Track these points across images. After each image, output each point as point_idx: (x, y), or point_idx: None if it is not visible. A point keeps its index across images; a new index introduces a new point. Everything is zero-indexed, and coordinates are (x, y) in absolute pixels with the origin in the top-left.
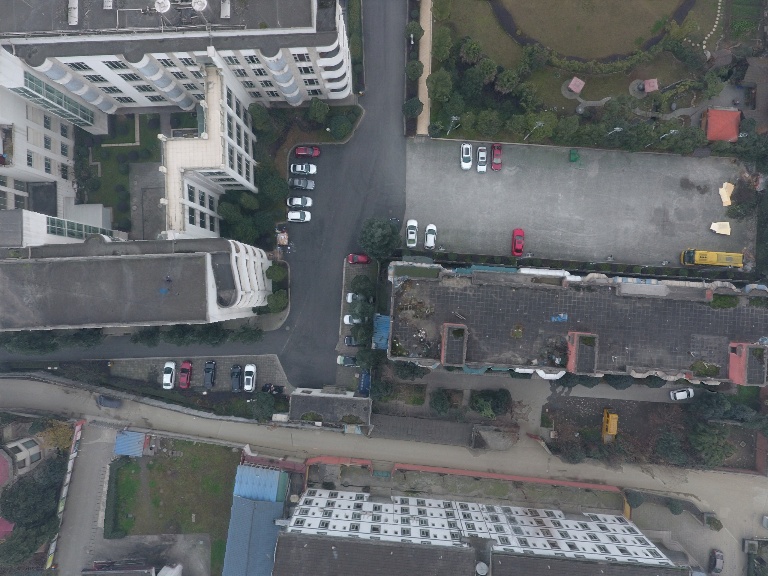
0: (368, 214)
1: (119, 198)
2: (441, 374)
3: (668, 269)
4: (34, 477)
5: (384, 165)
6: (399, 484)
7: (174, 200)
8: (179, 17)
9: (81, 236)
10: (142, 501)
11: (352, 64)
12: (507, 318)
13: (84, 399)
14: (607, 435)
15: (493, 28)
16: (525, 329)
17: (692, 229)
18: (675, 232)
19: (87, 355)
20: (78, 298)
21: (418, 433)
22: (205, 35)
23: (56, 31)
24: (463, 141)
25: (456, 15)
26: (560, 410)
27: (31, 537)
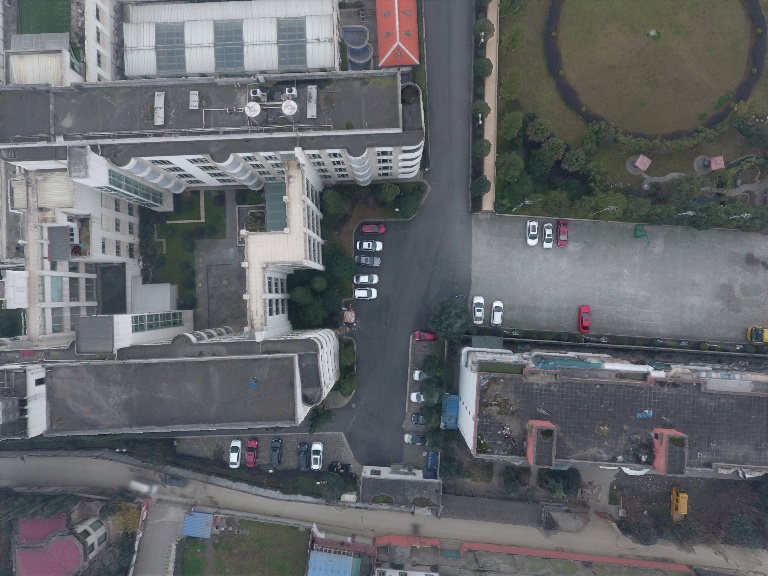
0: (434, 290)
1: (184, 275)
2: None
3: (735, 345)
4: (104, 563)
5: (450, 241)
6: (467, 563)
7: (255, 294)
8: (266, 117)
9: (157, 326)
10: None
11: None
12: (592, 414)
13: (149, 477)
14: (676, 513)
15: (557, 104)
16: (610, 425)
17: (758, 305)
18: (741, 308)
19: None
20: (164, 399)
21: (488, 513)
22: (292, 135)
23: (142, 131)
24: (528, 217)
25: None
26: (628, 487)
27: None
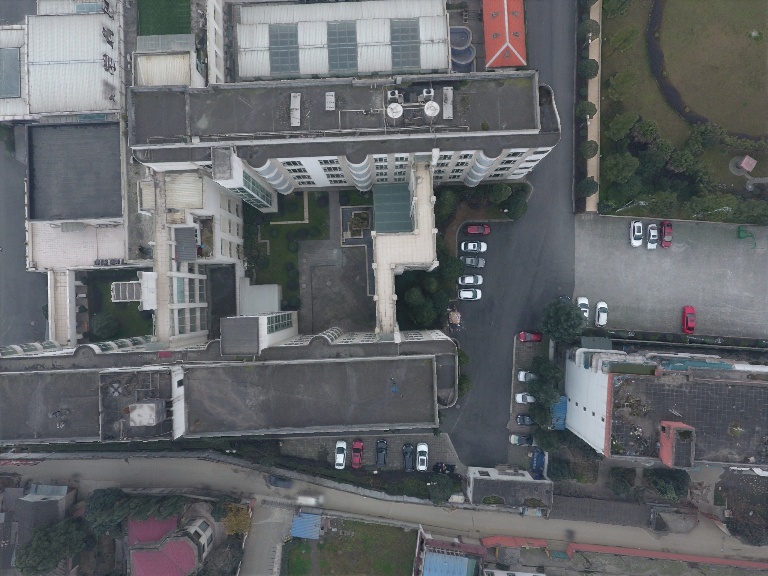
0: (538, 291)
1: (289, 276)
2: None
3: None
4: (218, 564)
5: (553, 242)
6: (573, 564)
7: (384, 295)
8: (402, 118)
9: (279, 327)
10: None
11: None
12: (724, 415)
13: (253, 478)
14: None
15: (660, 105)
16: (742, 426)
17: None
18: None
19: None
20: (301, 400)
21: (596, 514)
22: (429, 136)
23: (278, 132)
24: (632, 218)
25: None
26: (733, 488)
27: None
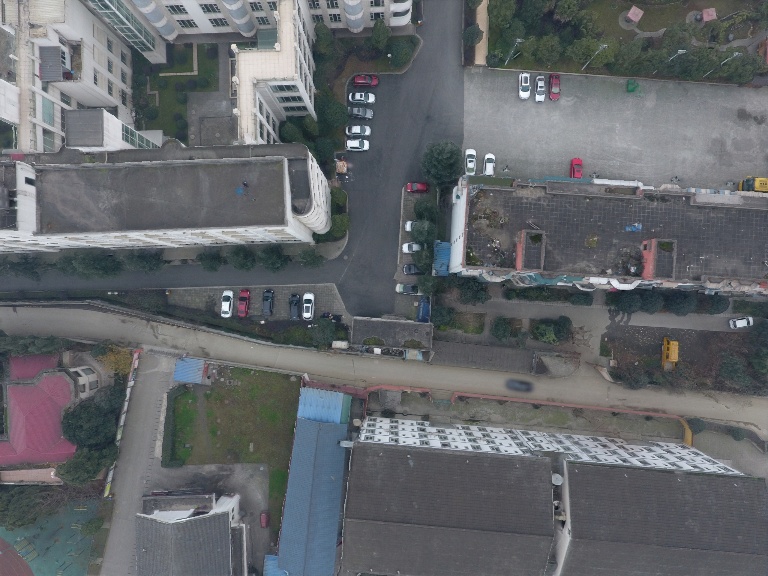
0: (426, 144)
1: (177, 127)
2: (500, 303)
3: None
4: (95, 400)
5: (442, 95)
6: (458, 413)
7: (246, 112)
8: None
9: None
10: (199, 431)
11: None
12: (581, 228)
13: (141, 328)
14: (667, 363)
15: None
16: (599, 239)
17: (750, 159)
18: (733, 162)
19: (144, 284)
20: (154, 204)
21: (479, 360)
22: None
23: None
24: (521, 71)
25: None
26: (619, 339)
27: (94, 459)
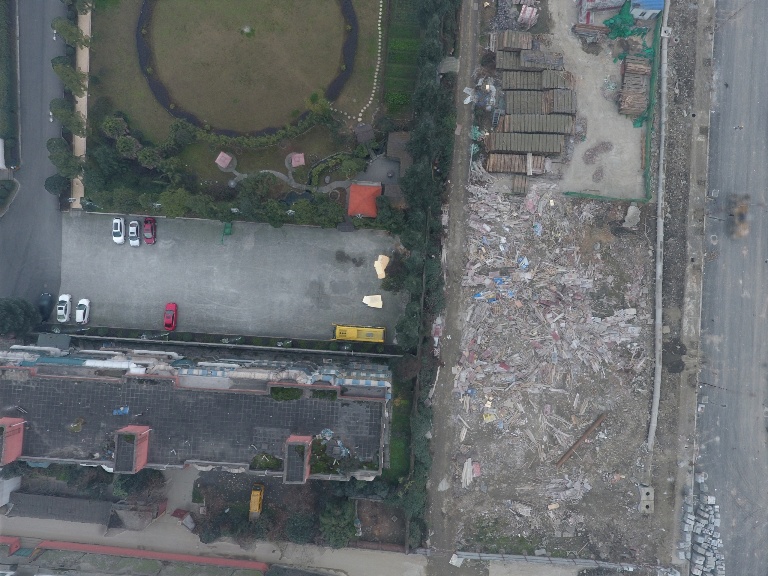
0: (22, 289)
1: None
2: None
3: (320, 343)
4: None
5: (39, 239)
6: (47, 562)
7: None
8: None
9: None
10: None
11: (4, 139)
12: (69, 411)
13: None
14: None
15: (150, 102)
16: (87, 422)
17: (347, 302)
18: (330, 305)
19: None
20: None
21: (58, 512)
22: None
23: None
24: (118, 215)
25: (113, 89)
26: (212, 485)
27: None
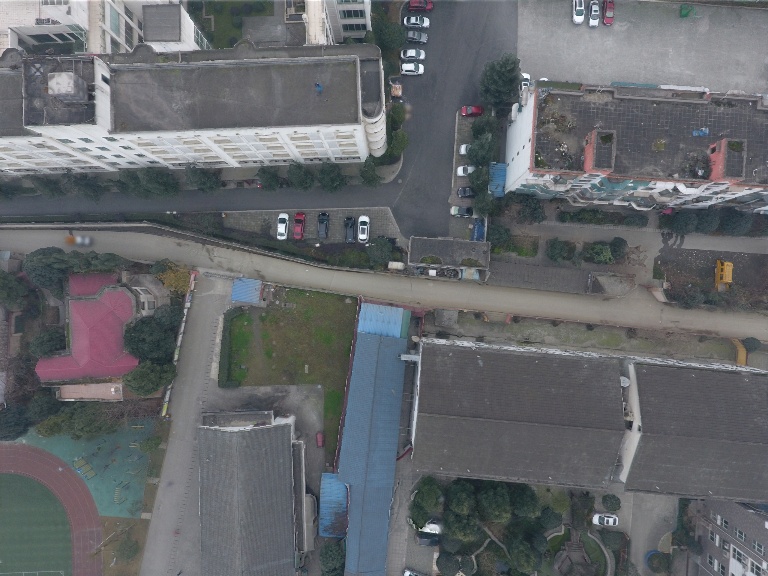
0: (480, 68)
1: None
2: (553, 226)
3: None
4: (156, 316)
5: (496, 20)
6: (512, 335)
7: (314, 19)
8: None
9: None
10: (255, 352)
11: None
12: (648, 133)
13: (196, 252)
14: (720, 285)
15: None
16: (666, 143)
17: None
18: None
19: (200, 207)
20: (227, 104)
21: (534, 280)
22: None
23: None
24: None
25: None
26: (672, 262)
27: (156, 372)
